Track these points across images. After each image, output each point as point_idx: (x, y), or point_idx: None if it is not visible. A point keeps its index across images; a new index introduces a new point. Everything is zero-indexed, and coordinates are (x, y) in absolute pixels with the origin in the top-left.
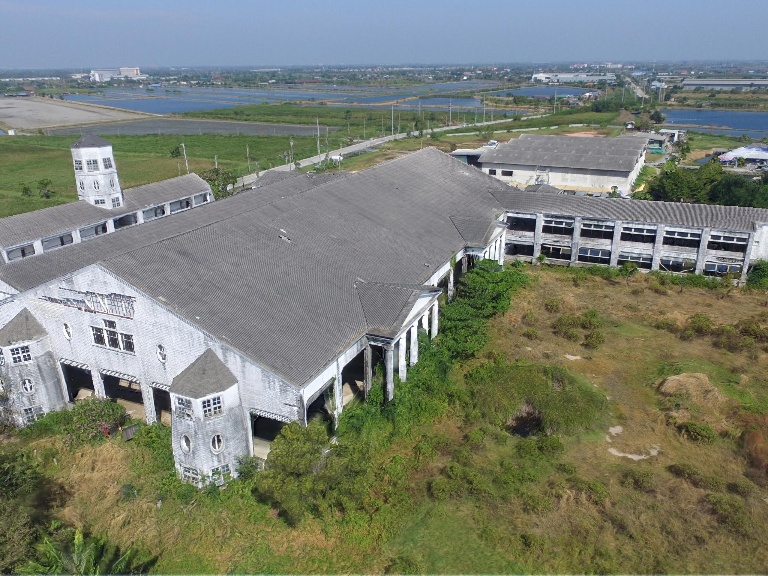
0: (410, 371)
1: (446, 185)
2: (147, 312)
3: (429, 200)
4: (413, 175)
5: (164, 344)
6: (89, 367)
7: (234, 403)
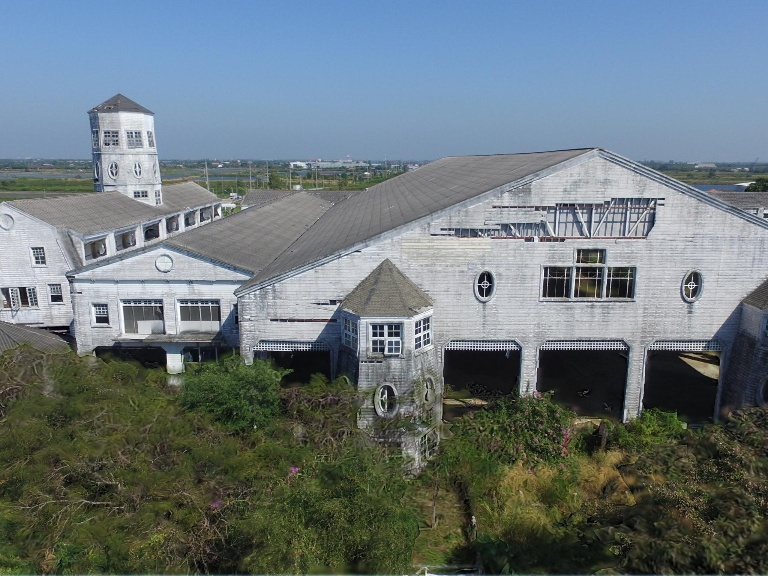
0: None
1: None
2: (682, 220)
3: None
4: None
5: (701, 269)
6: (520, 343)
7: None
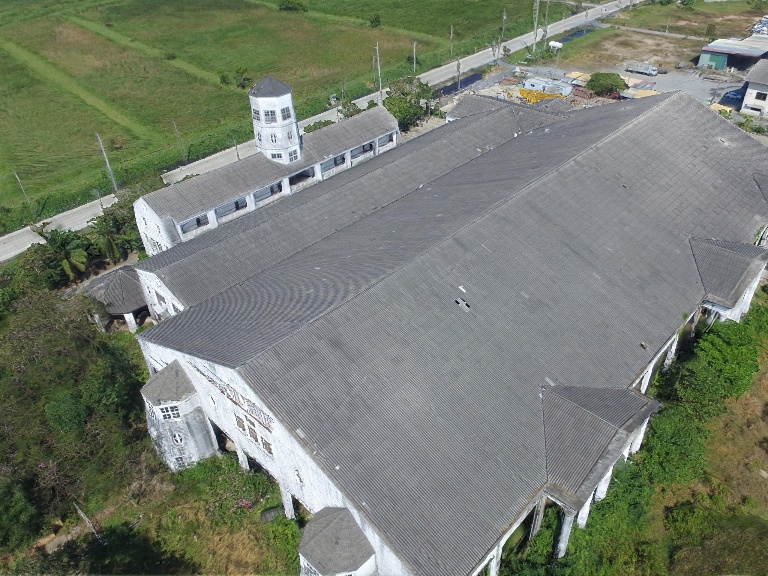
0: (593, 515)
1: (693, 171)
2: (285, 438)
3: (665, 206)
4: (649, 155)
5: (301, 472)
6: (233, 440)
7: (369, 572)
